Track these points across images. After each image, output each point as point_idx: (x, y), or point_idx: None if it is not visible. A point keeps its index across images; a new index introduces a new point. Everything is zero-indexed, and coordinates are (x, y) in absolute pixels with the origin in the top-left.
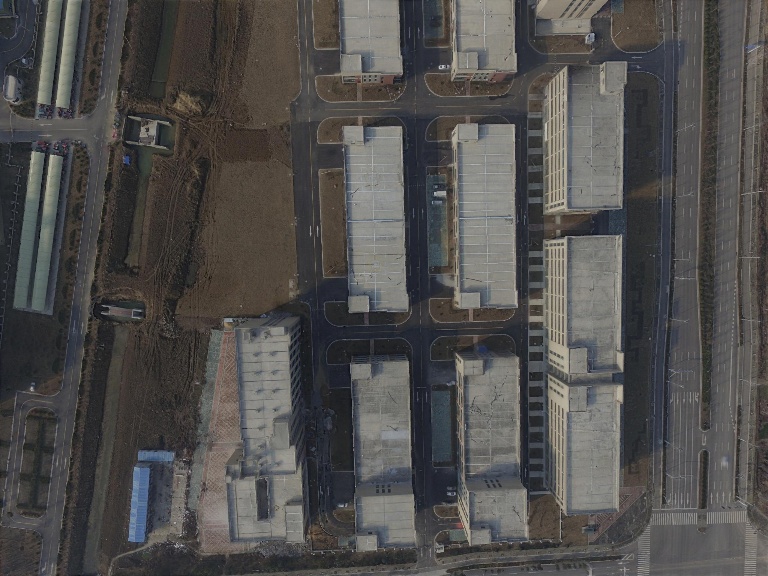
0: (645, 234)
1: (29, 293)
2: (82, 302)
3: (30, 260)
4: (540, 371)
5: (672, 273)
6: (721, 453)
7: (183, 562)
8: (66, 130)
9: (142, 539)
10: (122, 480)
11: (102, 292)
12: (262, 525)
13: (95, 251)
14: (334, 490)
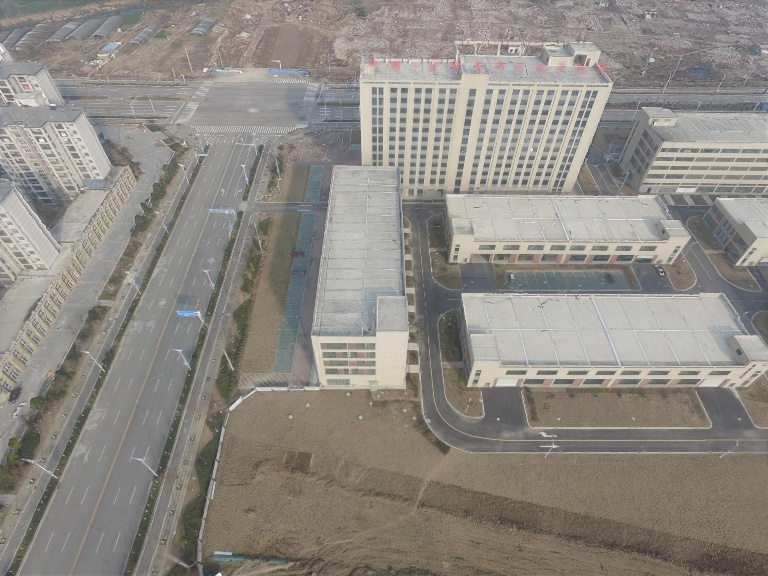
0: None
1: None
2: None
3: None
4: None
5: None
6: None
7: None
8: None
9: None
10: None
11: None
12: None
13: None
14: None
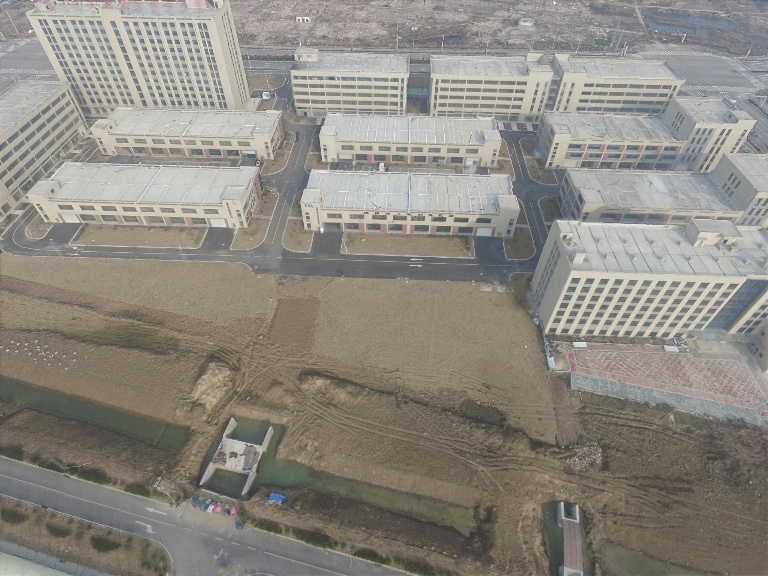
0: None
1: None
2: None
3: None
4: None
5: None
6: None
7: None
8: None
9: None
10: None
11: None
12: None
13: None
14: None
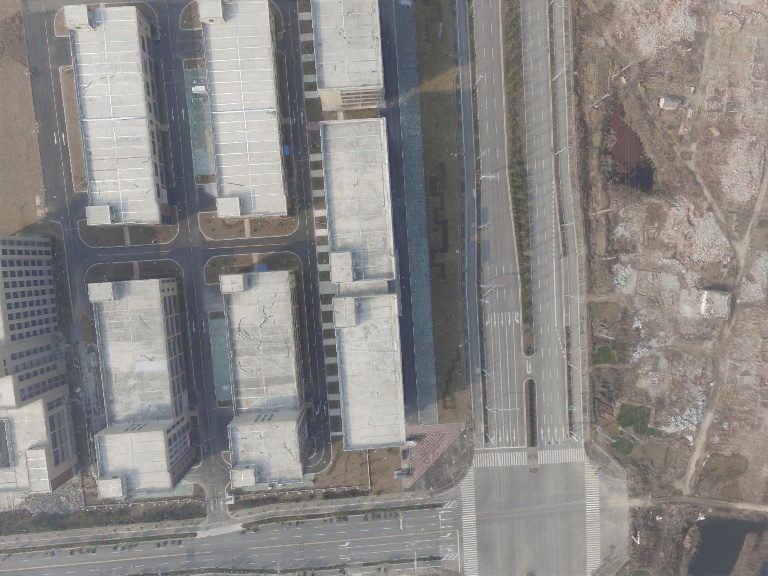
0: (443, 130)
1: None
2: None
3: None
4: (332, 293)
5: (478, 174)
6: (550, 382)
7: None
8: None
9: None
10: None
11: None
12: (5, 474)
13: None
14: None
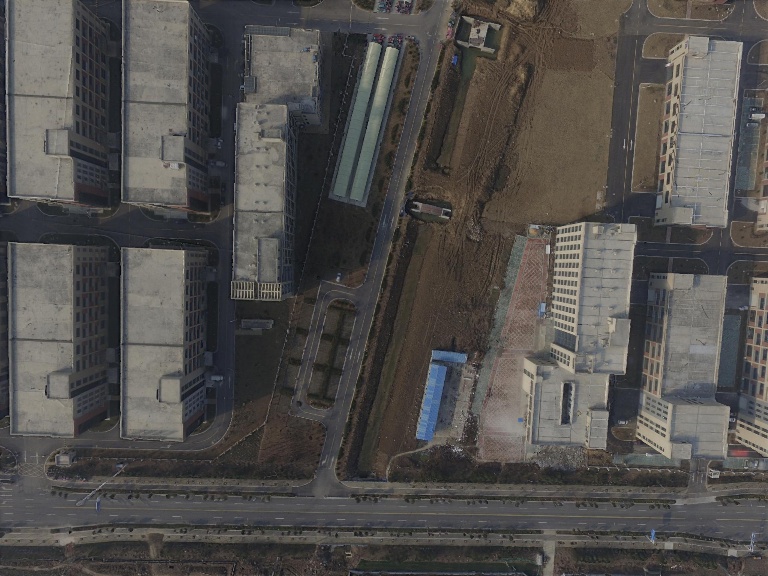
0: None
1: (349, 183)
2: (395, 197)
3: (355, 150)
4: None
5: None
6: None
7: (460, 466)
8: (401, 25)
9: (431, 437)
10: (411, 379)
11: (416, 188)
12: (562, 430)
13: (414, 147)
14: (615, 407)
